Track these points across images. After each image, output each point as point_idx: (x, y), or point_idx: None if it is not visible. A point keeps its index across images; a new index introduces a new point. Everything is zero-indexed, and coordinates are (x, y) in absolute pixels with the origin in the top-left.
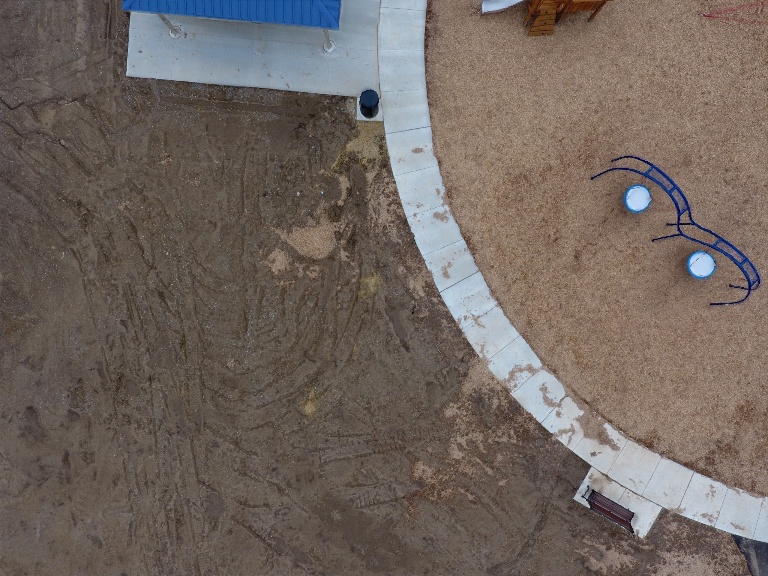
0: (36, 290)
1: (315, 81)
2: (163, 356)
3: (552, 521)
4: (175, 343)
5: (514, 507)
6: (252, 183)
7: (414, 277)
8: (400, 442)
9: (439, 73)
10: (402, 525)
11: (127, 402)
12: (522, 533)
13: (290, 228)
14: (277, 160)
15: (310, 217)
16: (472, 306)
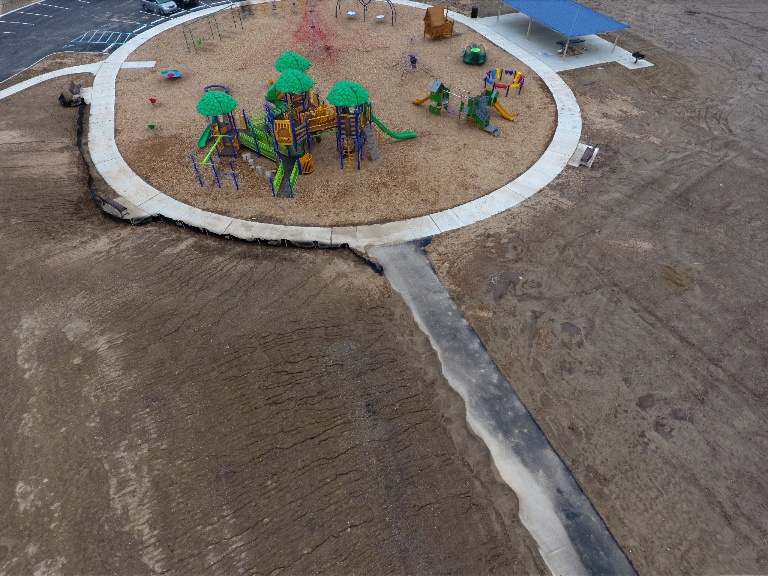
0: None
1: (494, 17)
2: None
3: None
4: None
5: None
6: None
7: (432, 3)
8: None
9: (461, 25)
10: None
11: None
12: None
13: (474, 2)
14: (489, 8)
15: (470, 4)
16: (411, 3)
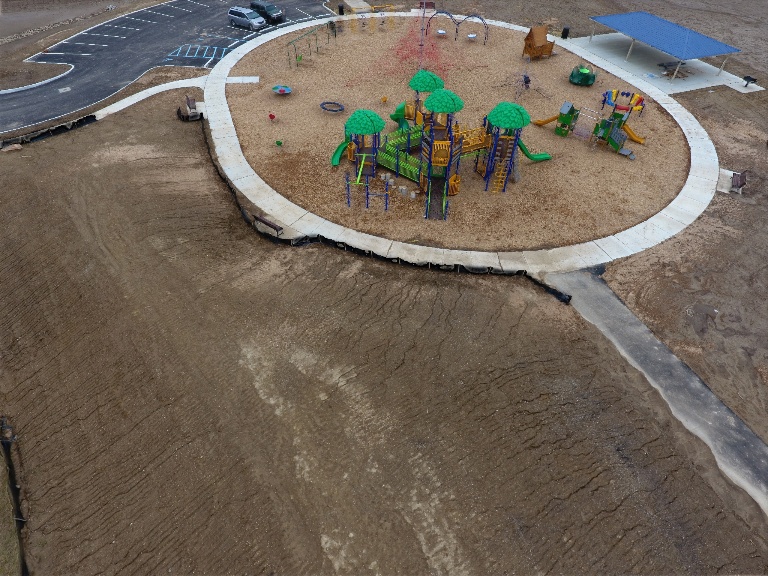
0: (604, 7)
1: (585, 38)
2: (563, 6)
3: (439, 6)
4: (562, 7)
5: (451, 6)
6: (577, 25)
7: None
8: (491, 7)
9: None
10: (477, 0)
11: (562, 1)
12: (445, 4)
13: None
14: None
15: None
16: None
